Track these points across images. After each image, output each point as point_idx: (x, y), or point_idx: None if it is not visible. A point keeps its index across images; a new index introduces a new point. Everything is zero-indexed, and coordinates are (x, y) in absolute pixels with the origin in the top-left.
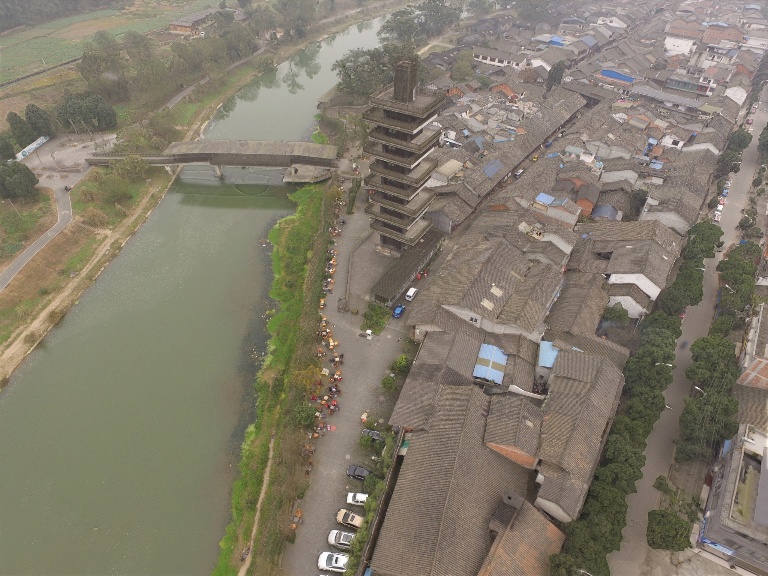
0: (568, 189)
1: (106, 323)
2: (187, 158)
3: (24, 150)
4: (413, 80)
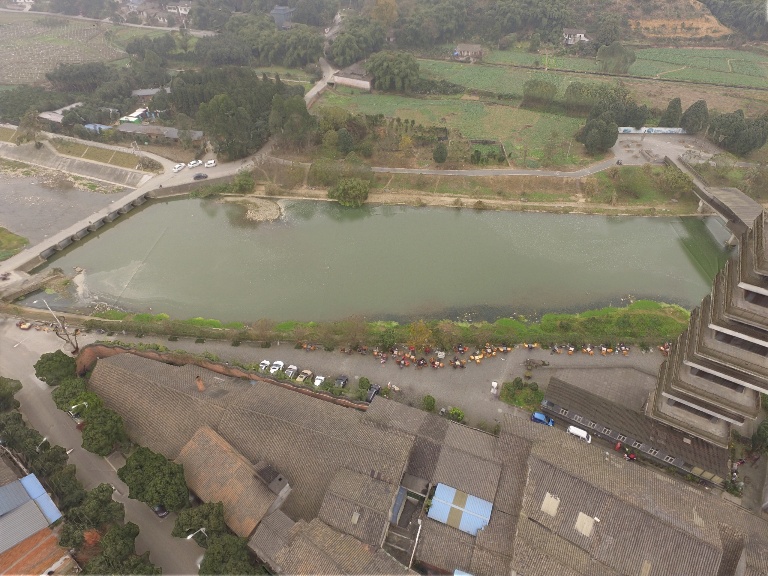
0: None
1: (481, 229)
2: (721, 206)
3: (653, 128)
4: None
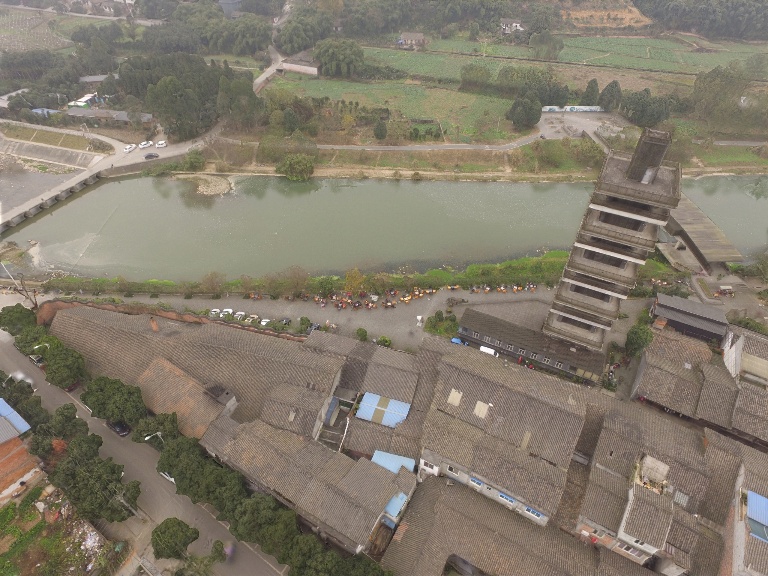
0: None
1: (418, 196)
2: None
3: (575, 107)
4: (650, 157)
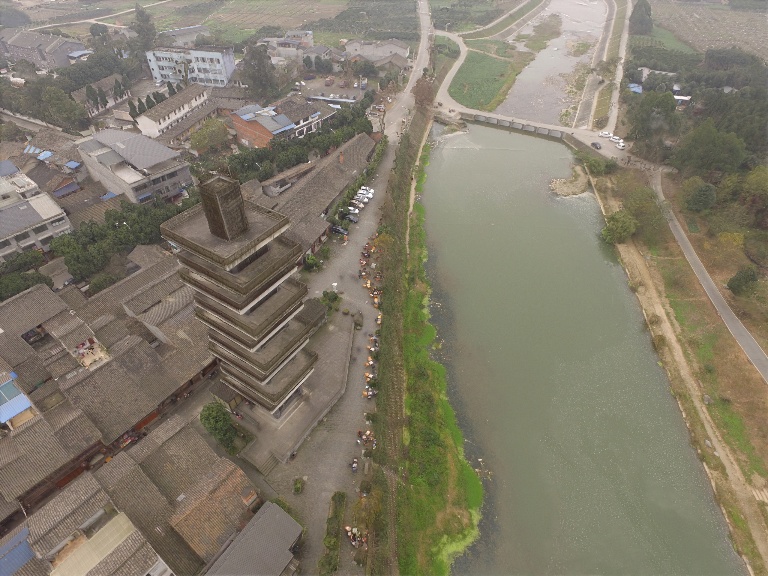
0: None
1: (602, 338)
2: None
3: None
4: None
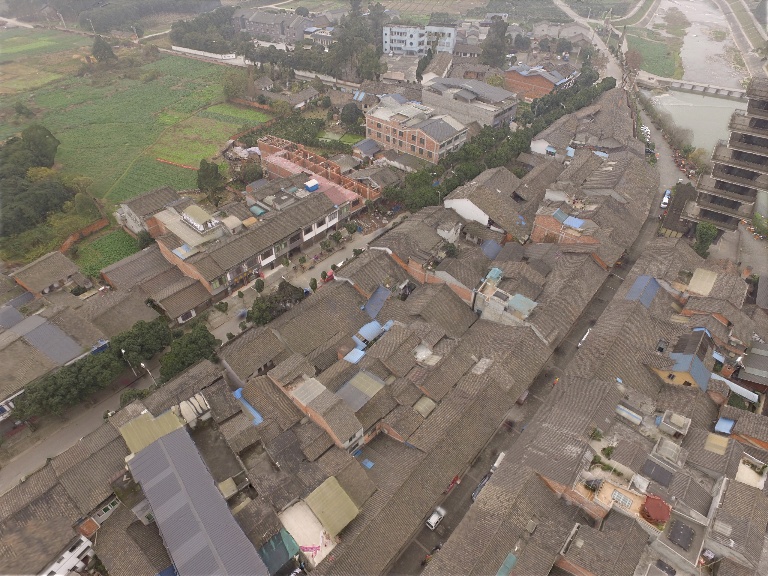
0: (535, 260)
1: None
2: None
3: None
4: None
